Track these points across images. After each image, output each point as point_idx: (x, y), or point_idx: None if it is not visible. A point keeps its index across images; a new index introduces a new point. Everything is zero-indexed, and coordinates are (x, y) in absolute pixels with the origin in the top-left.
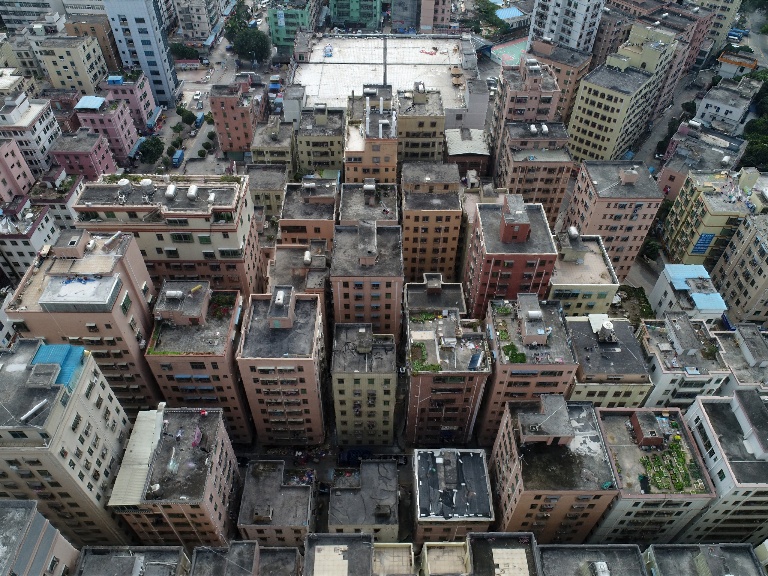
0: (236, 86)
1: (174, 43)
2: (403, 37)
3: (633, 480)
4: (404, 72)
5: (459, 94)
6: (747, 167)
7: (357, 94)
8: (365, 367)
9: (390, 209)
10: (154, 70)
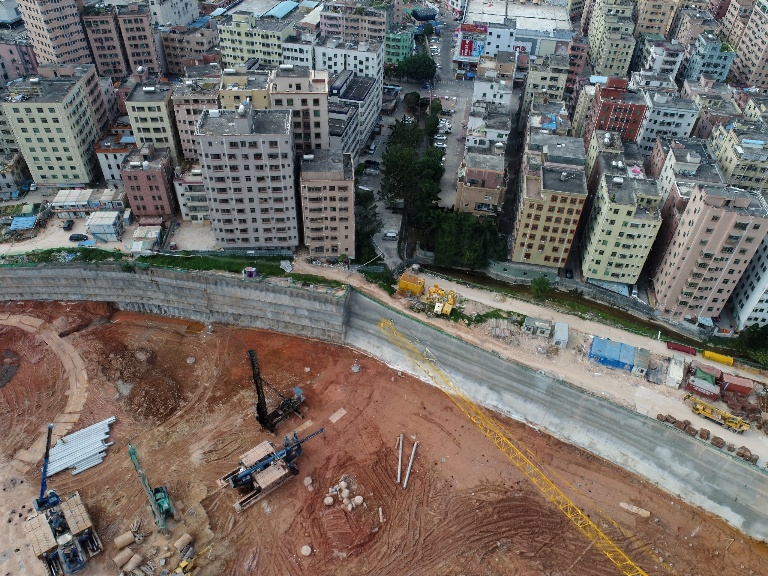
0: None
1: (412, 93)
2: (466, 8)
3: None
4: None
5: (546, 5)
6: None
7: (550, 24)
8: None
9: None
10: None
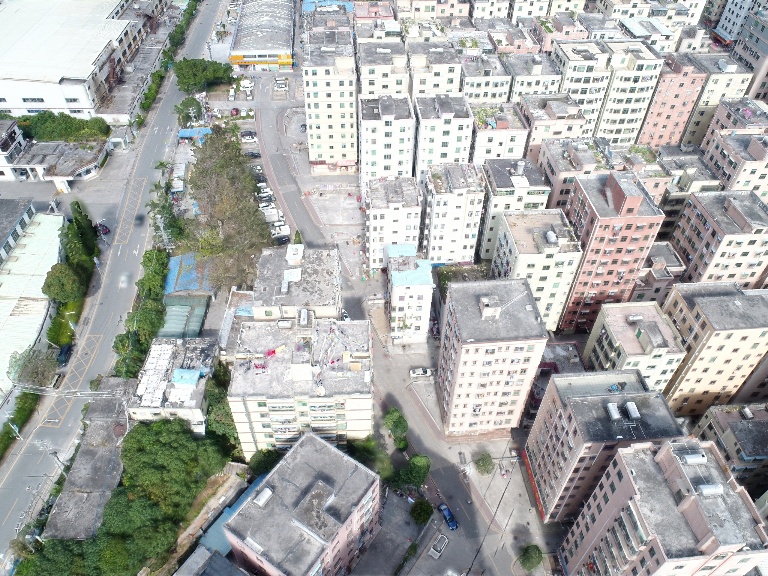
0: None
1: None
2: None
3: (507, 112)
4: None
5: None
6: (303, 364)
7: None
8: (679, 162)
9: None
10: None
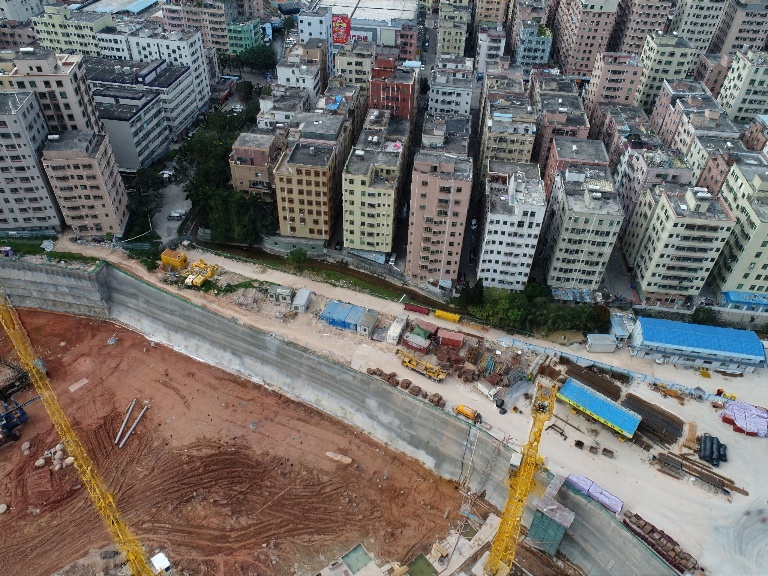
0: (408, 23)
1: (243, 82)
2: (319, 0)
3: None
4: (369, 4)
5: None
6: None
7: (395, 15)
8: None
9: (531, 1)
10: (331, 68)
